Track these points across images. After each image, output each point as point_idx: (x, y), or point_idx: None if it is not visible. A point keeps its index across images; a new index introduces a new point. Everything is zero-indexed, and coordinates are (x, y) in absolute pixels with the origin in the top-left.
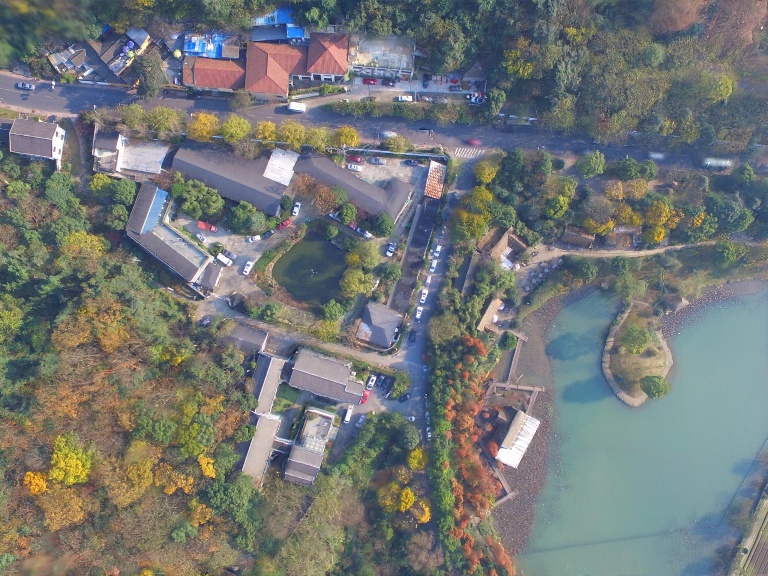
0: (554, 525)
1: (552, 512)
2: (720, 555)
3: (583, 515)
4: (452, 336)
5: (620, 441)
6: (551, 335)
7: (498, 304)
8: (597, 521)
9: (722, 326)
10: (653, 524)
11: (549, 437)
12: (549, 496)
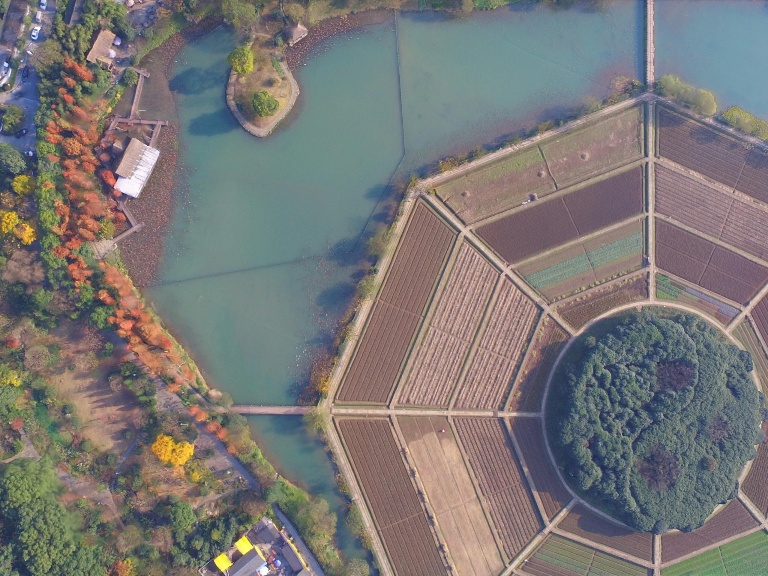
0: (184, 257)
1: (181, 244)
2: (355, 280)
3: (213, 246)
4: (52, 61)
5: (250, 173)
6: (174, 71)
7: (110, 37)
8: (230, 252)
9: (349, 56)
10: (286, 253)
11: (175, 170)
12: (177, 228)
